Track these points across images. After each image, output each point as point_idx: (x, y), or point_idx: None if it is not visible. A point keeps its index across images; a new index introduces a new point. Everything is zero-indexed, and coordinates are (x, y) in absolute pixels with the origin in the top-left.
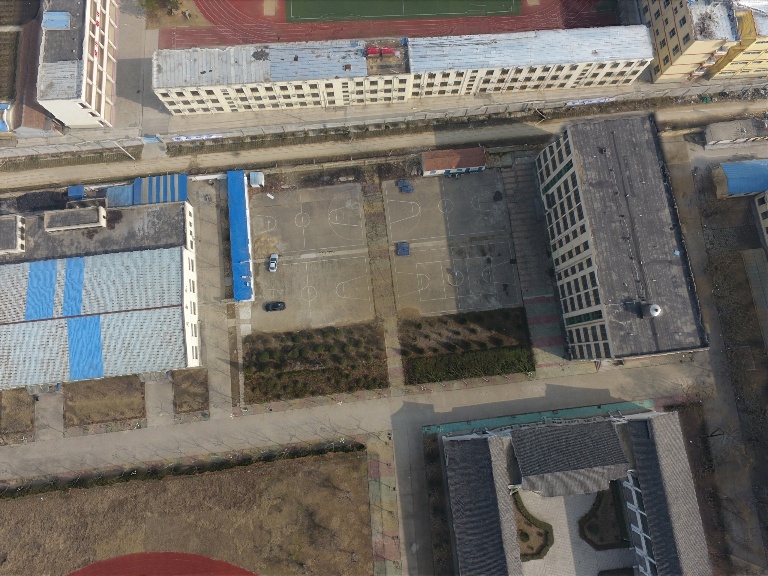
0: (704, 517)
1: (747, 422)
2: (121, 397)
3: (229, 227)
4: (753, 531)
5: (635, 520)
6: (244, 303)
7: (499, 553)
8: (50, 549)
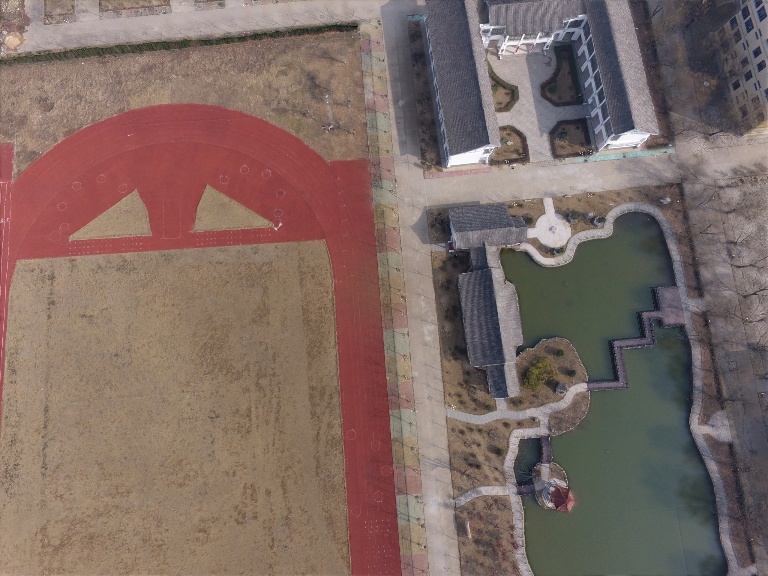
0: (647, 84)
1: (685, 15)
2: None
3: None
4: (689, 94)
5: (587, 74)
6: None
7: (470, 62)
8: (91, 100)
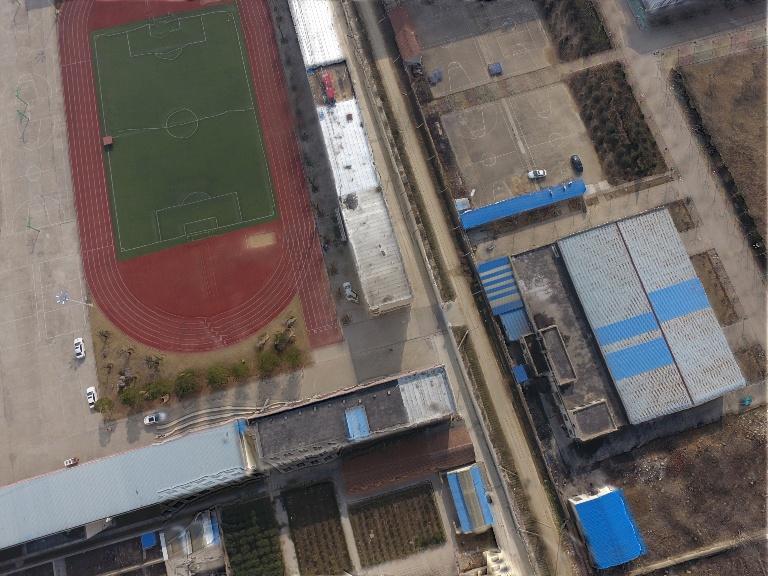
0: None
1: None
2: None
3: None
4: None
5: None
6: None
7: None
8: None
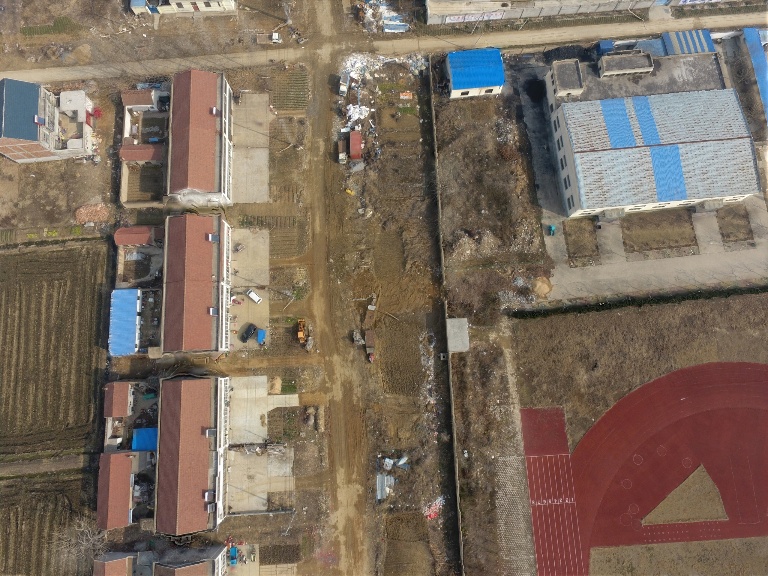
0: None
1: None
2: (672, 227)
3: (749, 78)
4: None
5: None
6: (767, 148)
7: None
8: (635, 357)
